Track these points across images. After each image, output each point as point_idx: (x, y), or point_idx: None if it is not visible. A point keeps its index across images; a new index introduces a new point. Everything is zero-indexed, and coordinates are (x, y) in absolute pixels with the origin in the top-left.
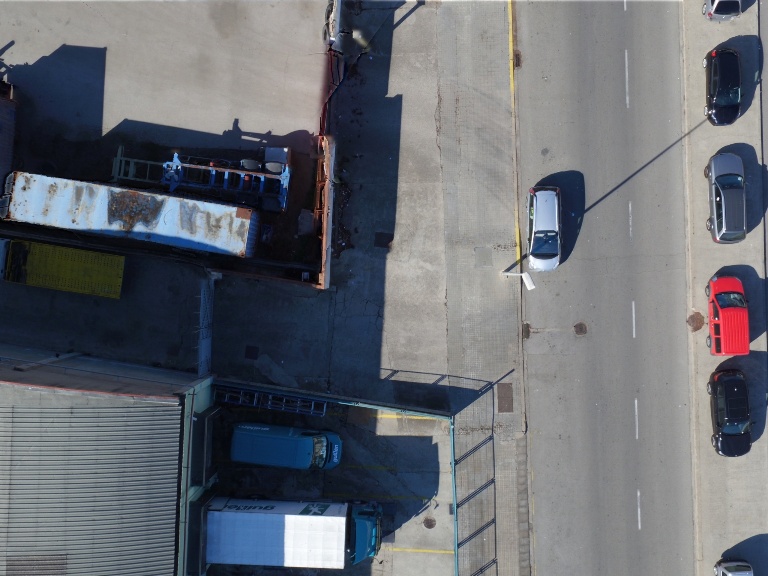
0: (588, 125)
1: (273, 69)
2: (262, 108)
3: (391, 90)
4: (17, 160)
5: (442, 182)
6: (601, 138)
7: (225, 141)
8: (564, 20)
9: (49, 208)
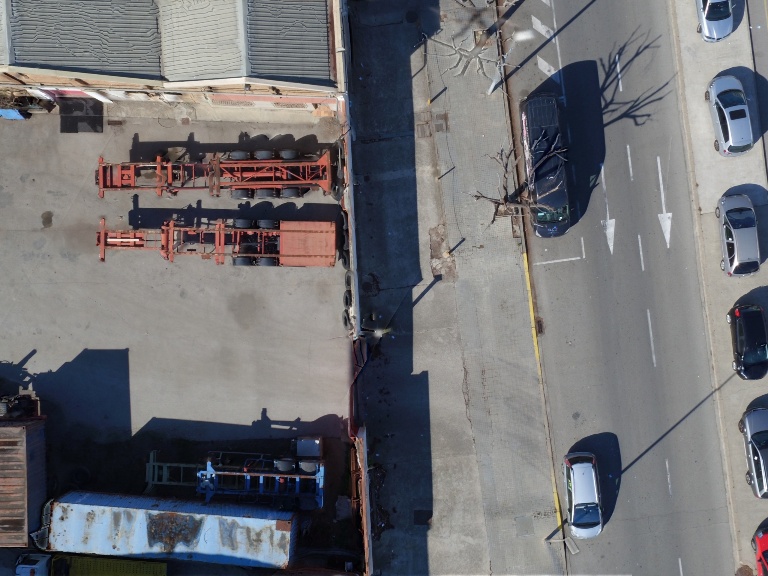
0: (617, 386)
1: (296, 356)
2: (289, 396)
3: (416, 367)
4: (51, 481)
5: (476, 454)
6: (631, 398)
7: (255, 431)
8: (583, 284)
9: (89, 536)
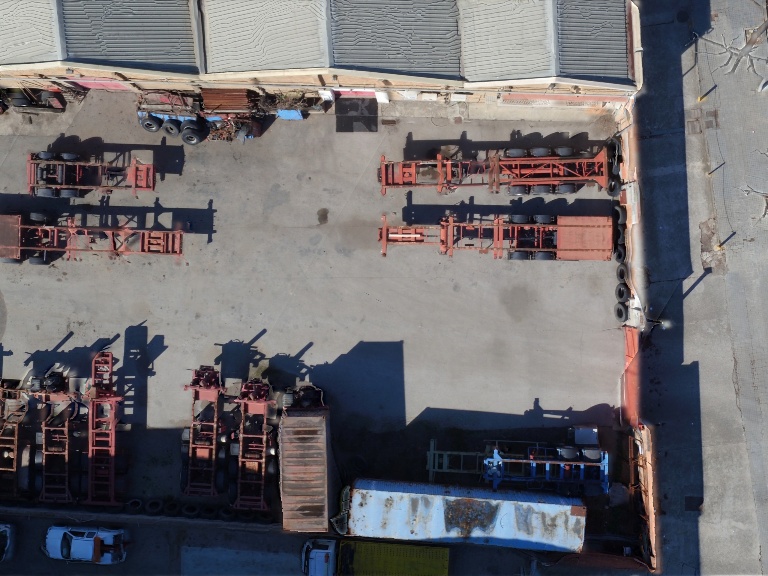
0: None
1: (568, 348)
2: (561, 386)
3: (687, 358)
4: (341, 469)
5: (746, 442)
6: None
7: (527, 421)
8: None
9: (387, 521)
